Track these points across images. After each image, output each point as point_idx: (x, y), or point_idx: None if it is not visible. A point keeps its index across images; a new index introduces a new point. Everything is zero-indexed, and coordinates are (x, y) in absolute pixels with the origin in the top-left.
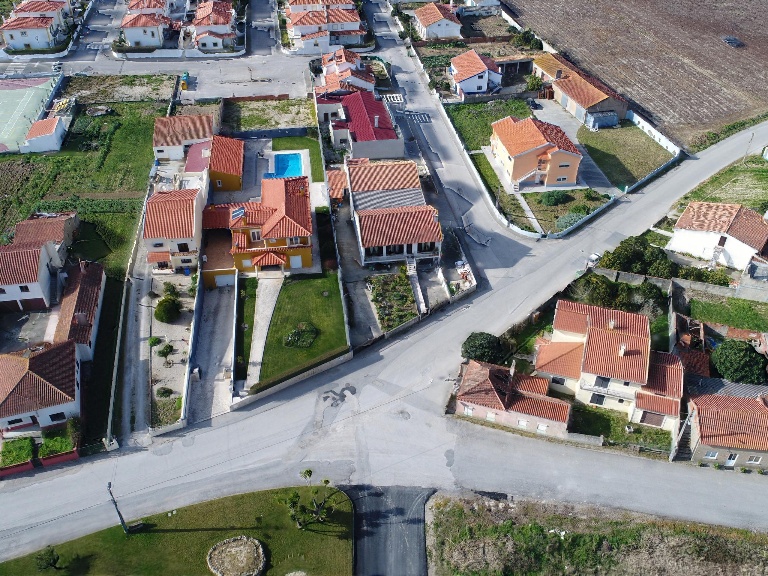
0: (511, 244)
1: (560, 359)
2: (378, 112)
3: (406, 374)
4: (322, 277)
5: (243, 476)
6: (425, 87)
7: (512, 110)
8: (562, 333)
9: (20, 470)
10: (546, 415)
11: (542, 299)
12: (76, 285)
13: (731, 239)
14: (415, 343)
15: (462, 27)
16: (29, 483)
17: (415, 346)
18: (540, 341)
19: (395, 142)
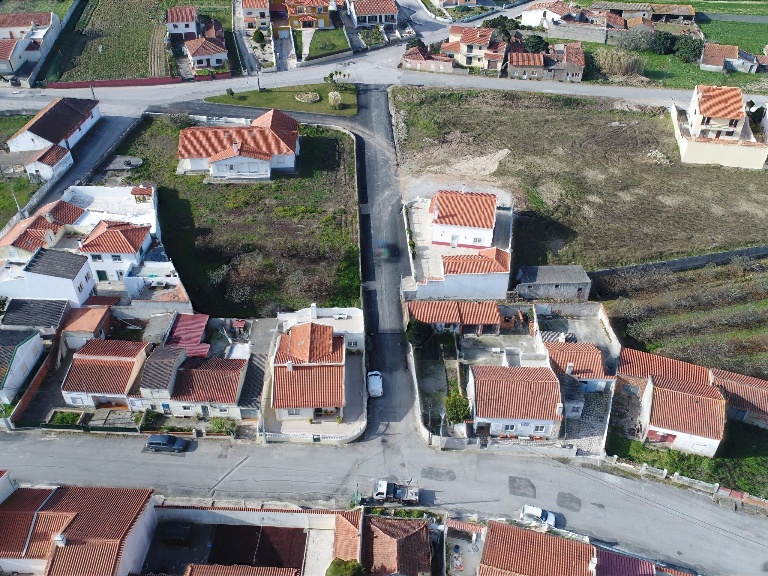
0: (436, 24)
1: (452, 46)
2: None
3: (379, 59)
4: (335, 30)
5: (306, 81)
6: None
7: None
8: (454, 36)
9: (206, 78)
10: (443, 61)
11: None
12: (212, 26)
13: (549, 12)
14: (384, 52)
15: None
16: (211, 82)
17: (384, 52)
18: None
19: None
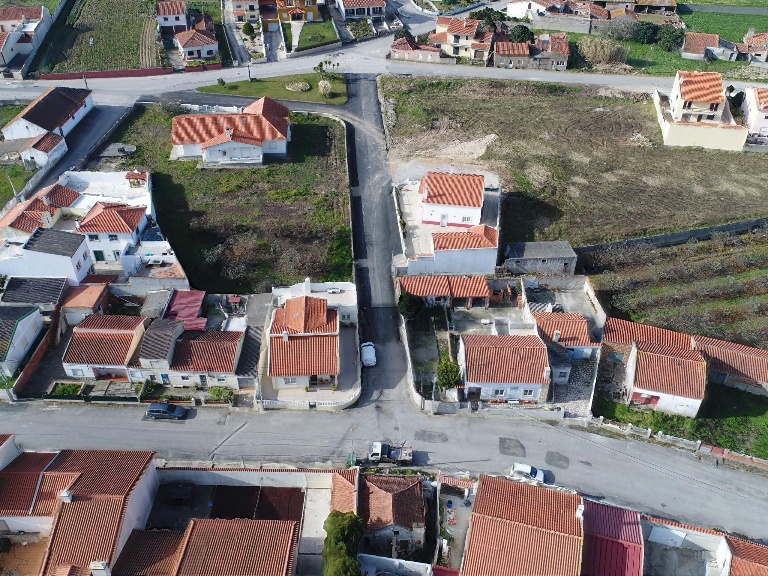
0: (423, 17)
1: (439, 36)
2: None
3: (368, 50)
4: (324, 22)
5: (296, 71)
6: None
7: None
8: (441, 27)
9: (197, 69)
10: None
11: None
12: (202, 19)
13: (534, 3)
14: (372, 43)
15: None
16: (202, 73)
17: (372, 43)
18: None
19: None
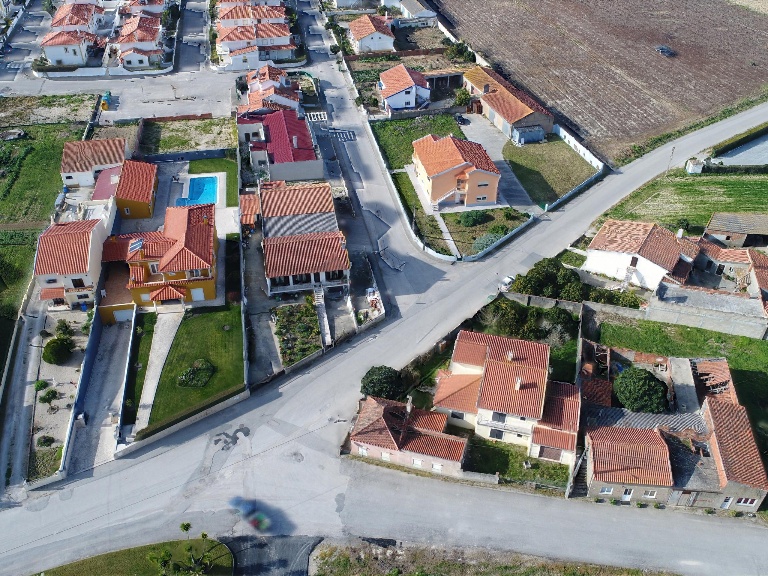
0: (425, 268)
1: (459, 393)
2: (299, 132)
3: (304, 412)
4: (225, 310)
5: (120, 531)
6: (353, 103)
7: (439, 126)
8: (462, 365)
9: None
10: (440, 454)
11: (452, 326)
12: None
13: (642, 260)
14: (316, 378)
15: (397, 39)
16: None
17: (316, 381)
18: (441, 373)
19: (313, 163)
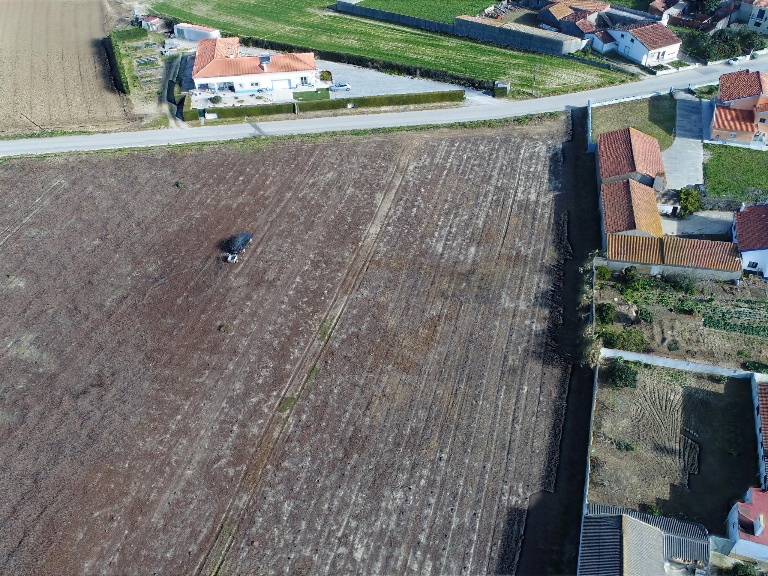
0: None
1: None
2: None
3: None
4: None
5: None
6: None
7: (733, 189)
8: None
9: None
10: None
11: None
12: None
13: None
14: None
15: (729, 468)
16: None
17: None
18: None
19: None
